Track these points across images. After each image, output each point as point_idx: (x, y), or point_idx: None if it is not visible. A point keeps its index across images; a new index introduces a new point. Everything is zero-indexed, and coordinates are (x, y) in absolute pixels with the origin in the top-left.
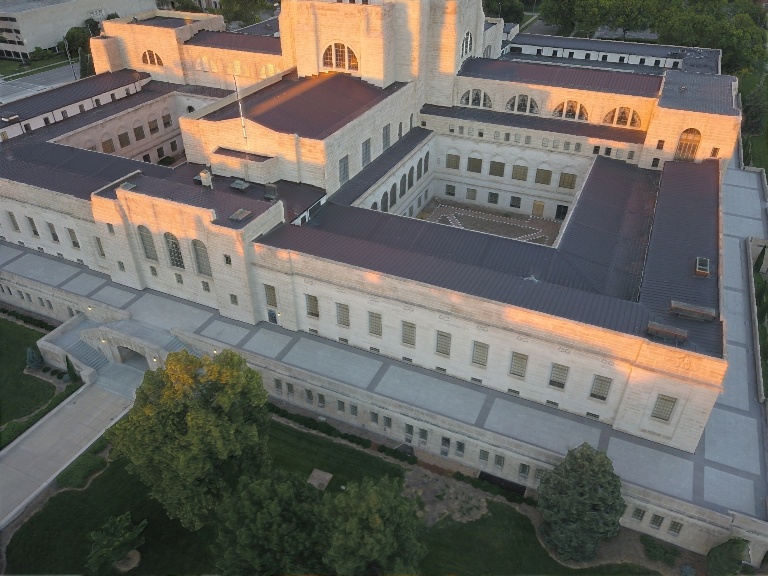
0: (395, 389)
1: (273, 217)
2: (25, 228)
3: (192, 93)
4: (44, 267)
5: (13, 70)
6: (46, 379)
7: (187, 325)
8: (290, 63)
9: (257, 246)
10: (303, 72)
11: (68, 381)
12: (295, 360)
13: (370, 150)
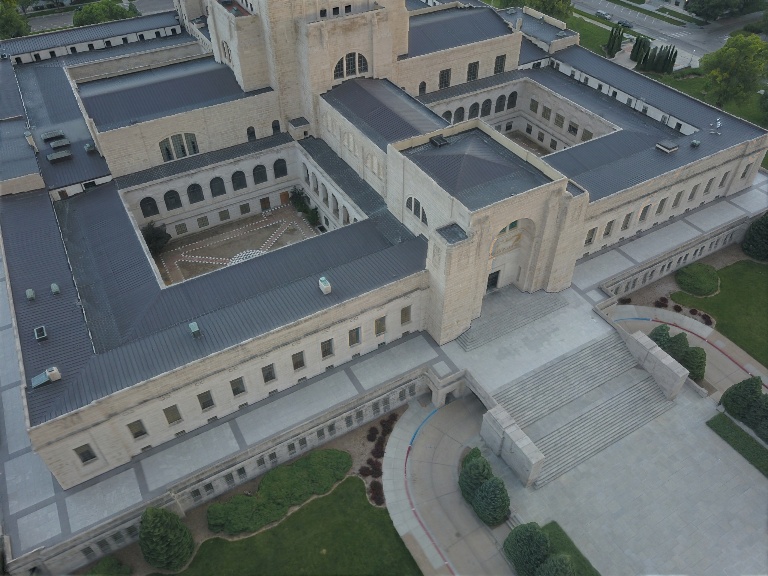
0: None
1: None
2: None
3: None
4: None
5: None
6: None
7: None
8: None
9: None
10: None
11: None
12: None
13: None
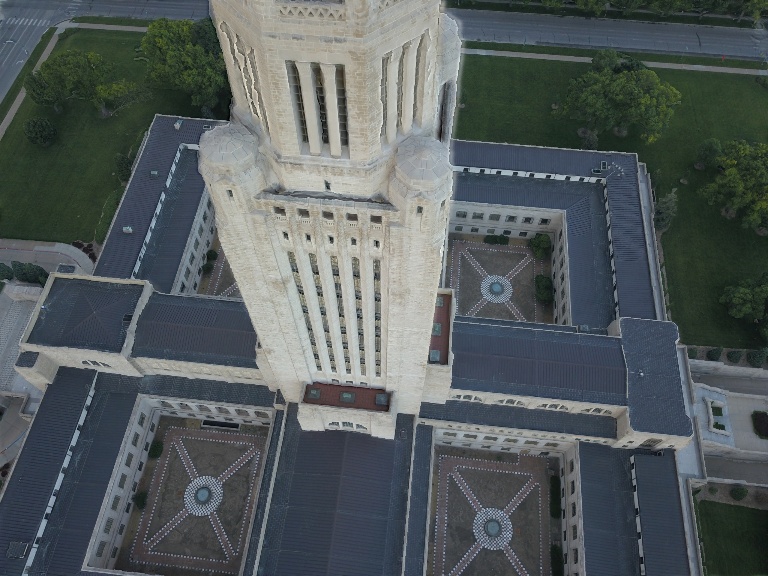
0: None
1: None
2: None
3: (159, 391)
4: None
5: None
6: None
7: None
8: (272, 379)
9: None
10: (308, 429)
11: None
12: None
13: None
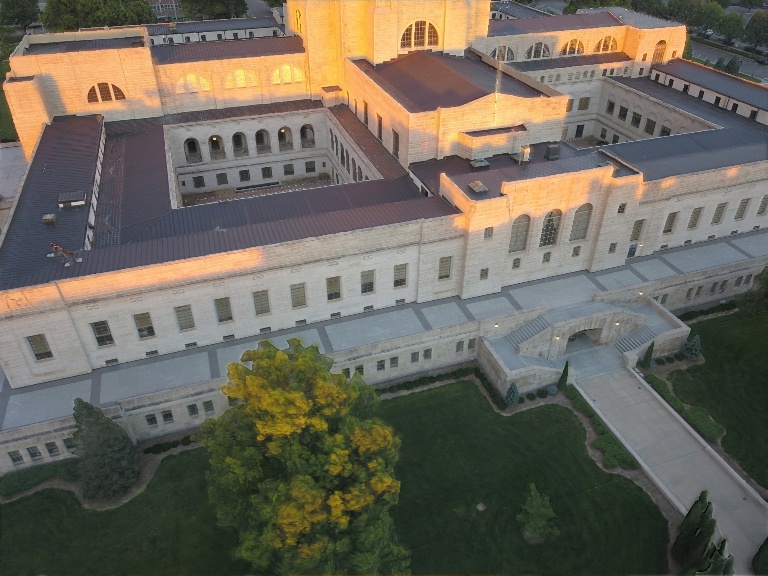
0: (760, 250)
1: None
2: (320, 296)
3: (187, 122)
4: (374, 326)
5: None
6: (535, 405)
7: (588, 291)
8: (318, 58)
9: (644, 185)
10: (381, 58)
11: (557, 393)
12: (690, 268)
13: None
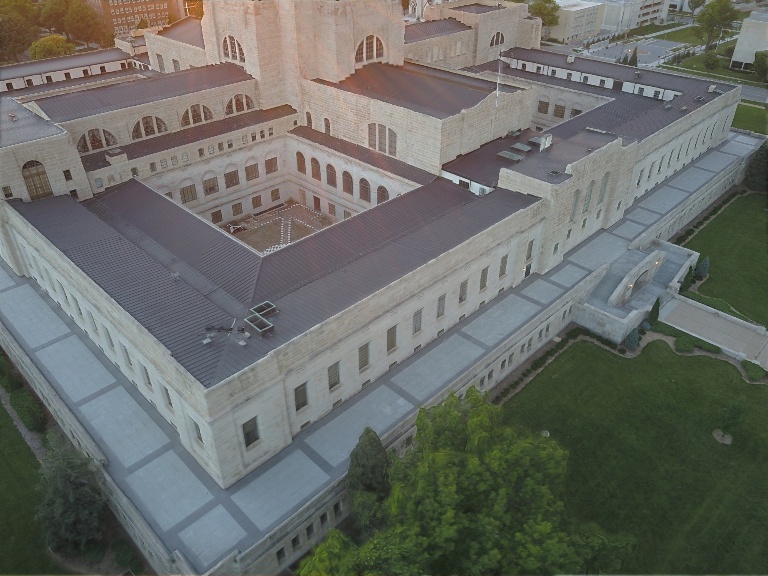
0: None
1: None
2: None
3: None
4: None
5: (692, 66)
6: None
7: None
8: None
9: None
10: None
11: None
12: None
13: None
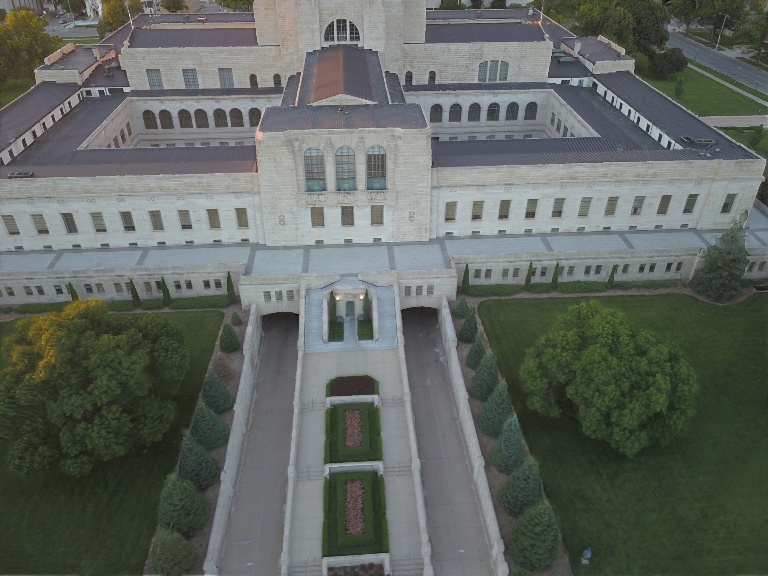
0: None
1: (67, 76)
2: None
3: None
4: None
5: None
6: None
7: None
8: None
9: None
10: None
11: None
12: None
13: (198, 79)
